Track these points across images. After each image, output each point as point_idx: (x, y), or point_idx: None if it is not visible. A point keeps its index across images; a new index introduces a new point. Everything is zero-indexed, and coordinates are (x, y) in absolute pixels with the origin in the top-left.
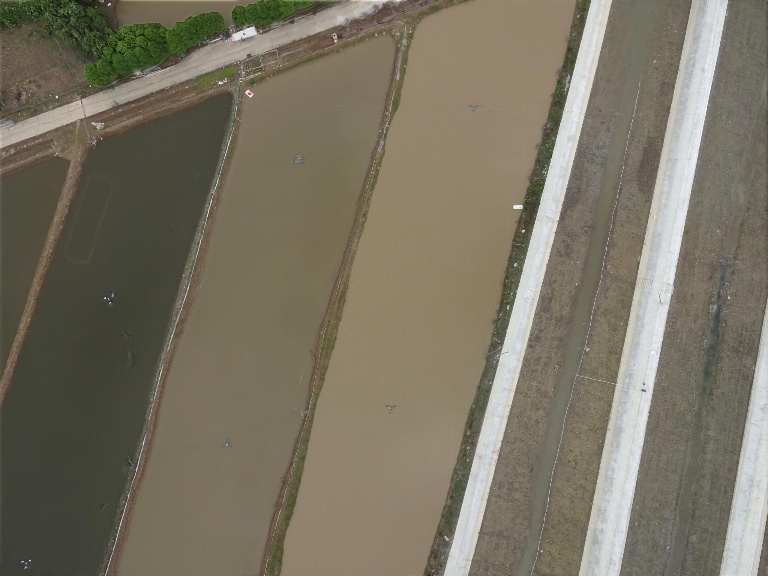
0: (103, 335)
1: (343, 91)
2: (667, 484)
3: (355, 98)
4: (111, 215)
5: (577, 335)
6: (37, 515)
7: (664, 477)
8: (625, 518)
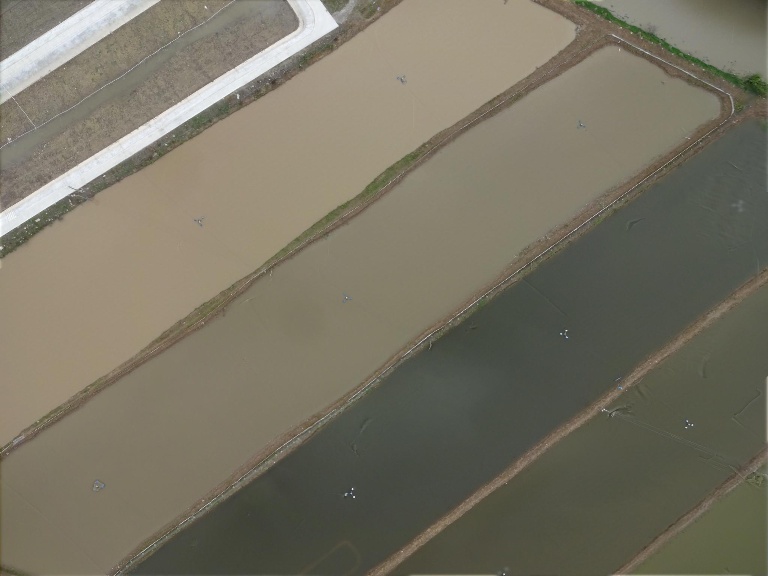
0: (373, 464)
1: (8, 518)
2: (45, 1)
3: (4, 503)
4: (295, 568)
5: (7, 156)
6: (530, 363)
7: (42, 7)
8: (97, 4)
